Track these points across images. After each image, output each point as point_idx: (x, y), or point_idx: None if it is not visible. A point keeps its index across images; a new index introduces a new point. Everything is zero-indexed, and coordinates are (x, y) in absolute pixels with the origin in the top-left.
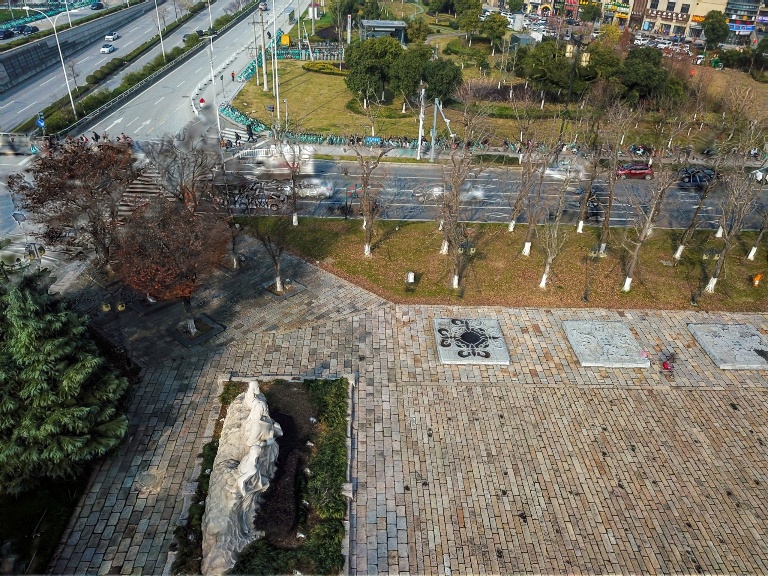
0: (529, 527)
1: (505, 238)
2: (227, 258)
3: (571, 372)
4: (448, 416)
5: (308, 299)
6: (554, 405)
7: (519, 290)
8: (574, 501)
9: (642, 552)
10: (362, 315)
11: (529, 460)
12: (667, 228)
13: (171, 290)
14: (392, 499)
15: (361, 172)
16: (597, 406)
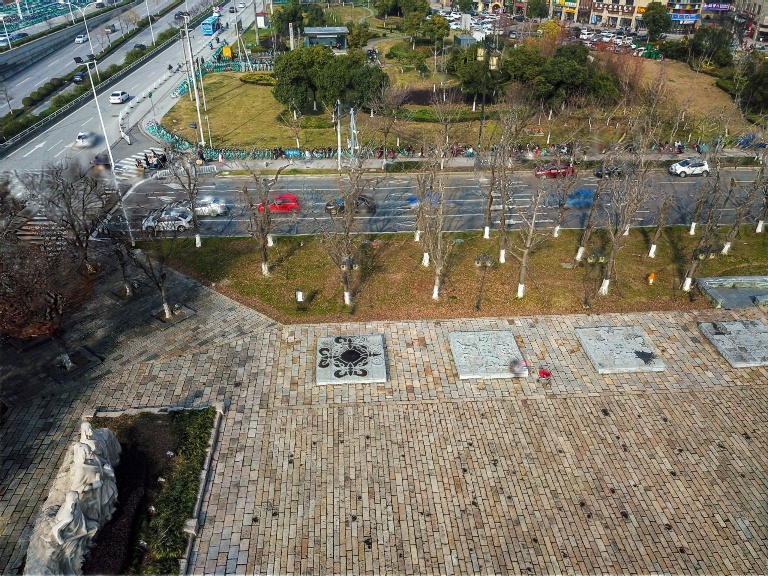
0: (373, 553)
1: (409, 248)
2: (121, 285)
3: (448, 386)
4: (313, 440)
5: (195, 324)
6: (424, 422)
7: (411, 303)
8: (424, 523)
9: (482, 572)
10: (247, 338)
11: (387, 482)
12: (577, 228)
13: (27, 329)
14: (238, 532)
15: (279, 186)
16: (467, 420)
